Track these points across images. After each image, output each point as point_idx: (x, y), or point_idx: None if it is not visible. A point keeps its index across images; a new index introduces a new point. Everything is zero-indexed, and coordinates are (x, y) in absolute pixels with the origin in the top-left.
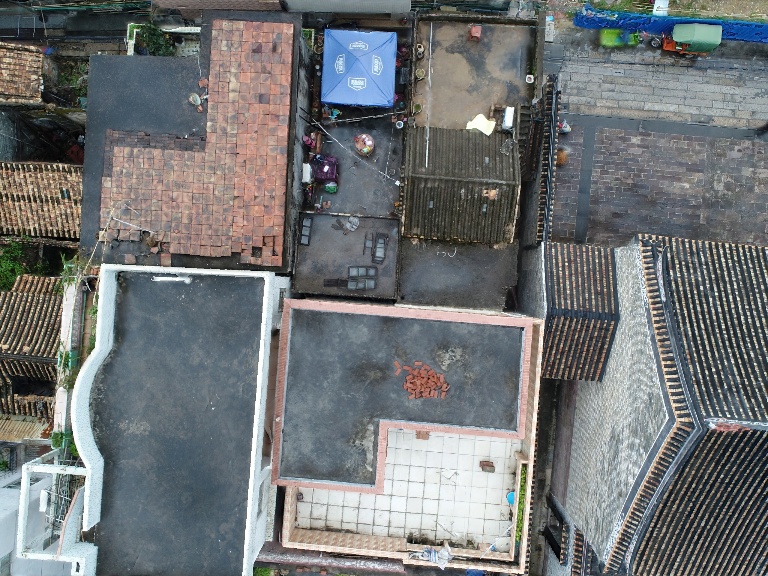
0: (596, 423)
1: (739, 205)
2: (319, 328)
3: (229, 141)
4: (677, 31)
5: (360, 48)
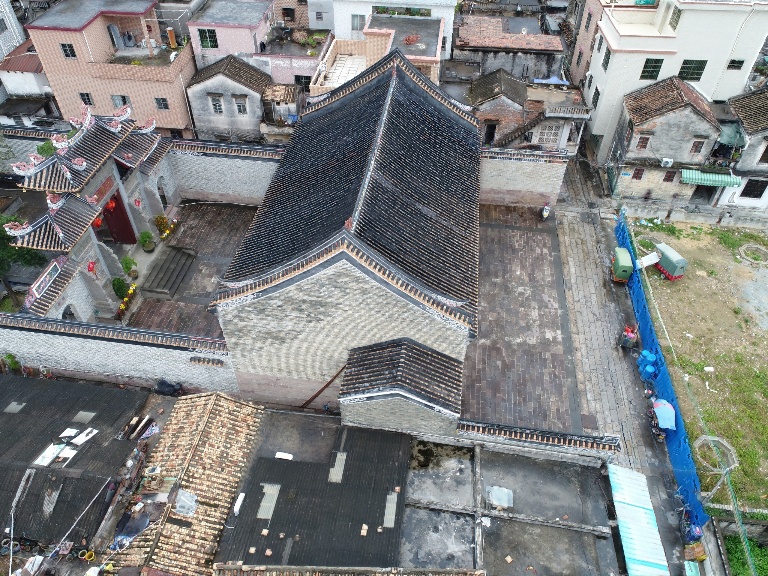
0: None
1: (508, 299)
2: (433, 24)
3: (508, 37)
4: (622, 249)
5: (561, 83)
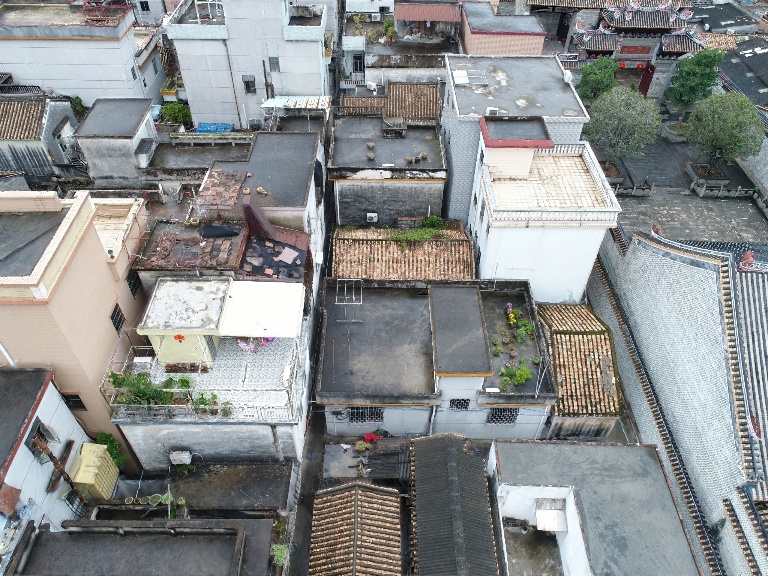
0: (517, 5)
1: None
2: None
3: None
4: None
5: None
